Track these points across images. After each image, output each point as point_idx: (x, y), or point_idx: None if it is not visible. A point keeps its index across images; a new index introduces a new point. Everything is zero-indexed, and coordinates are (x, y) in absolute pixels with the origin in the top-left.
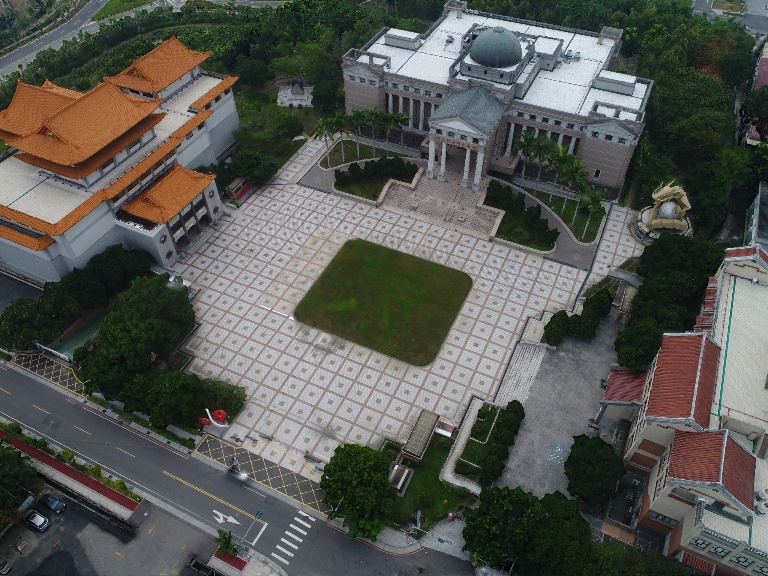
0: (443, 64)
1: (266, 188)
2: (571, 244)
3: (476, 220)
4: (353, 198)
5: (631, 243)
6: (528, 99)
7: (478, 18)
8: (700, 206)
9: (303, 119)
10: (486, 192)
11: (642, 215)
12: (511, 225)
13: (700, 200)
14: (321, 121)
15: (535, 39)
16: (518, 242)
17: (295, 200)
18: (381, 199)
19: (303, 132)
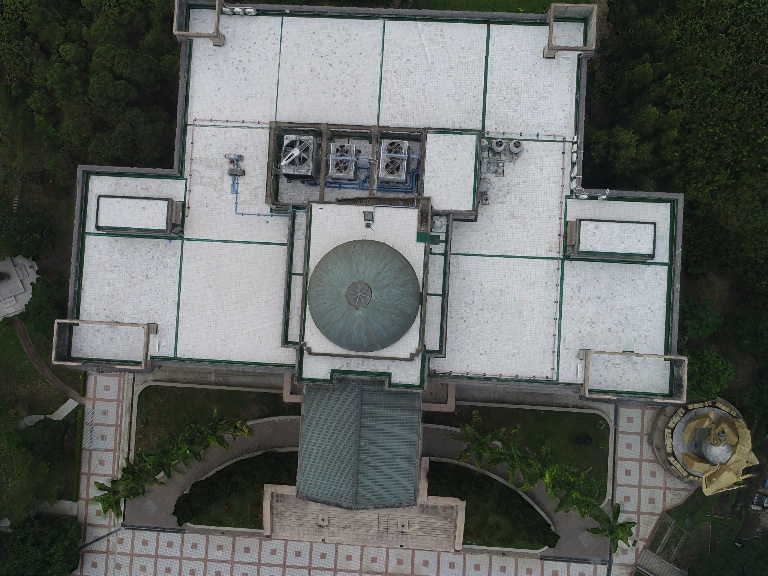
0: (254, 274)
1: (83, 557)
2: (573, 516)
3: (425, 522)
4: (224, 531)
5: (658, 479)
6: (455, 350)
7: (261, 29)
8: (764, 411)
9: (47, 351)
10: (426, 478)
11: (673, 440)
12: (480, 518)
13: (765, 404)
14: (102, 502)
15: (417, 132)
16: (498, 545)
17: (140, 569)
18: (268, 528)
19: (66, 388)
